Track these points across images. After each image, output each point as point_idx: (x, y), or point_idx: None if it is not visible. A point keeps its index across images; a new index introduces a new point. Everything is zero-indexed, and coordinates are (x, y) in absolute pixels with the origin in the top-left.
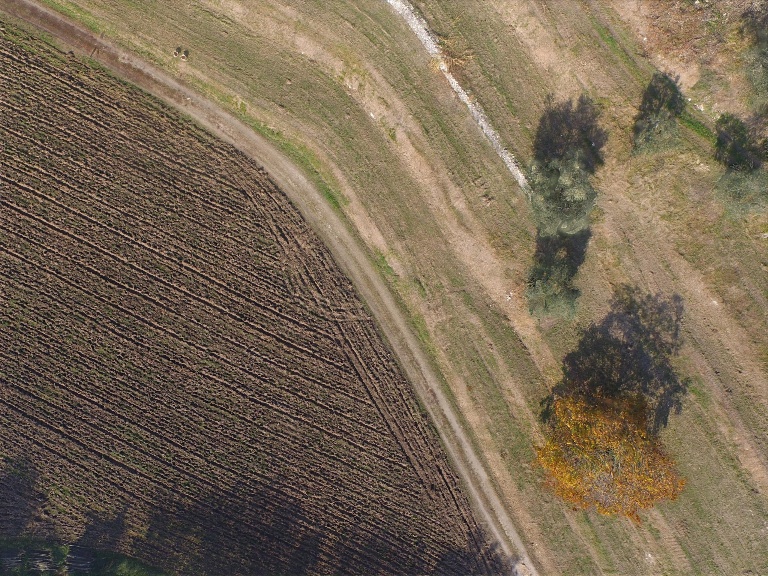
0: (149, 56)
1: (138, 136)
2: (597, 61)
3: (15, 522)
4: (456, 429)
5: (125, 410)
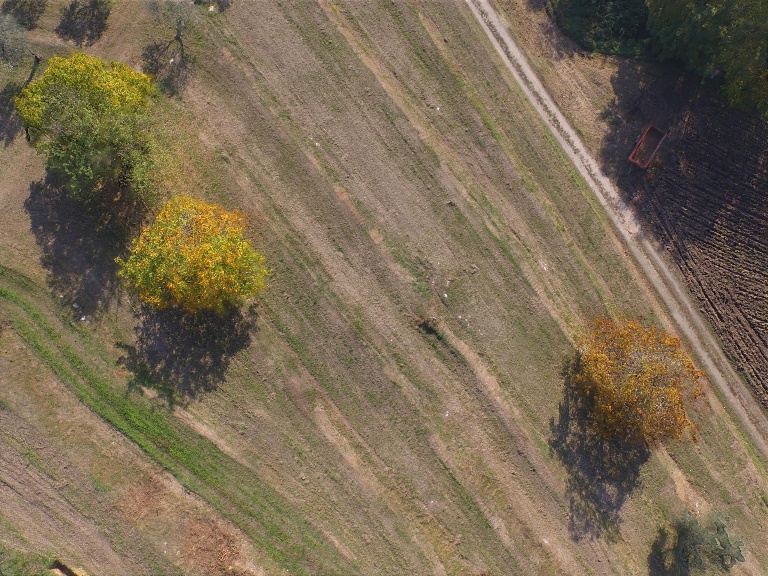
0: None
1: None
2: None
3: None
4: (708, 359)
5: None
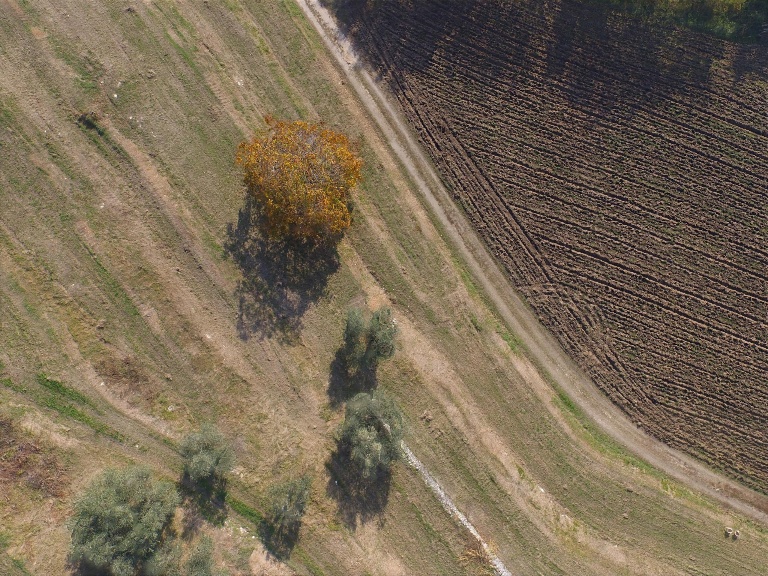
0: (761, 529)
1: (763, 448)
2: (345, 567)
3: None
4: (425, 188)
5: (746, 180)
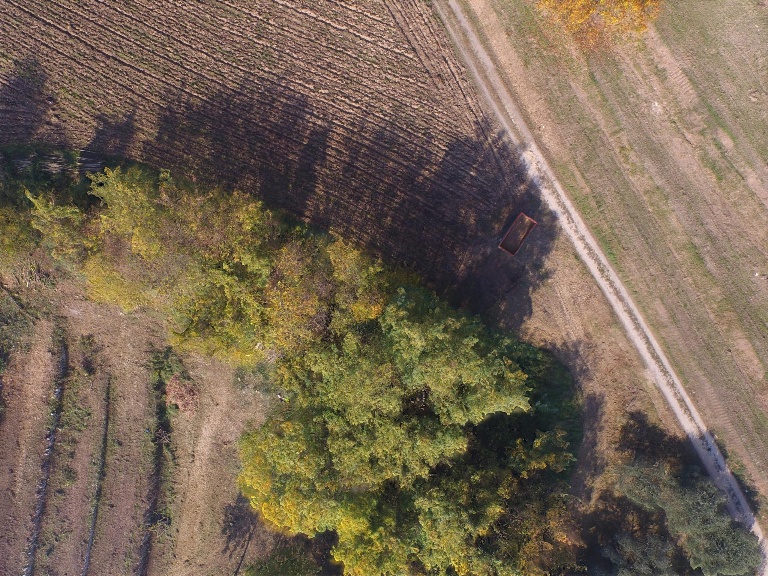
0: None
1: None
2: None
3: (26, 127)
4: (461, 19)
5: (132, 9)
